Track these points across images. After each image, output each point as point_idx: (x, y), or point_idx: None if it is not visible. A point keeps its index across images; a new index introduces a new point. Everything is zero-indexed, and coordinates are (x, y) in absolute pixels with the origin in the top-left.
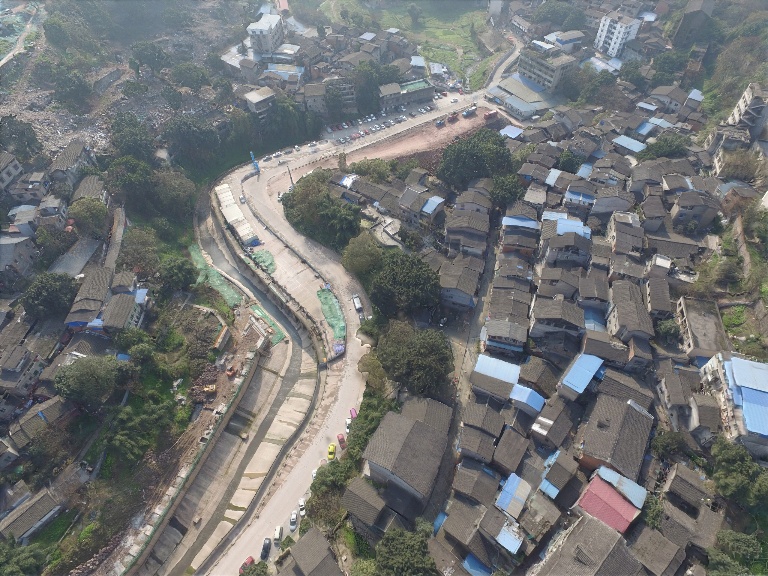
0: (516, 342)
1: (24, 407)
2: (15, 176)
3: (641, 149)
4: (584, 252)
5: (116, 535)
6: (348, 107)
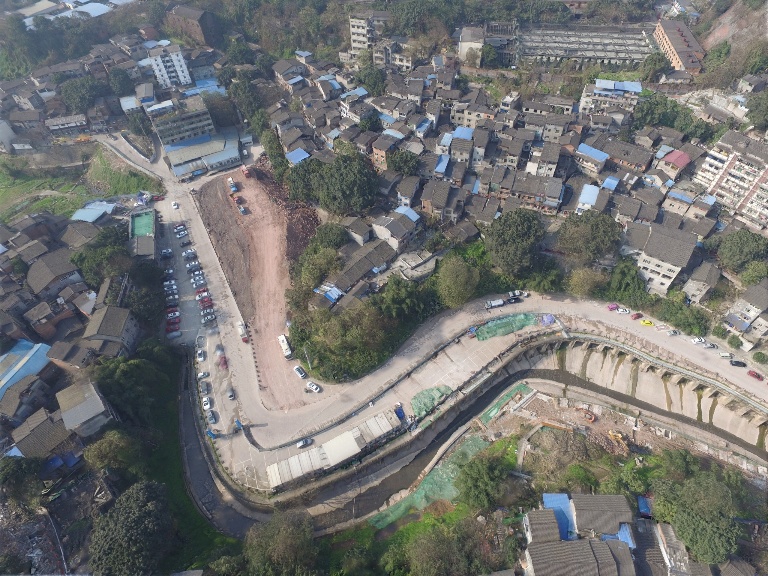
0: None
1: None
2: None
3: (365, 90)
4: None
5: None
6: None
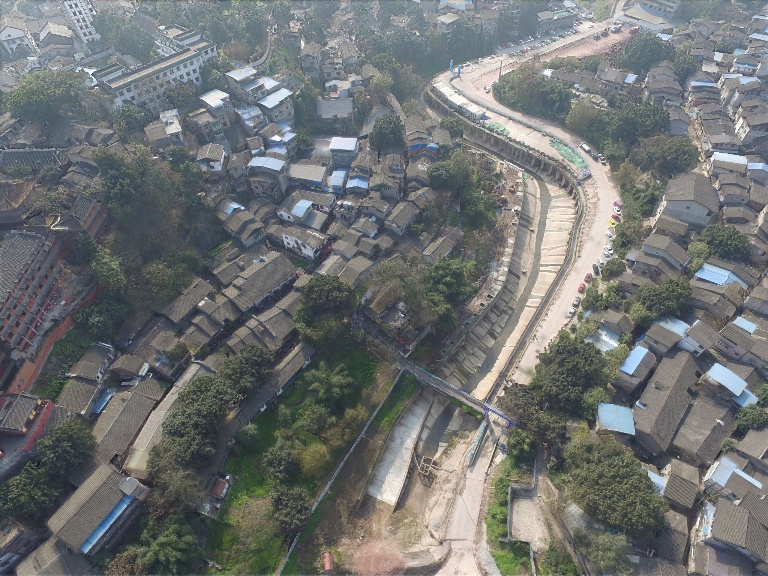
0: (734, 147)
1: (400, 196)
2: (320, 61)
3: None
4: (766, 93)
5: (486, 270)
6: (512, 30)
